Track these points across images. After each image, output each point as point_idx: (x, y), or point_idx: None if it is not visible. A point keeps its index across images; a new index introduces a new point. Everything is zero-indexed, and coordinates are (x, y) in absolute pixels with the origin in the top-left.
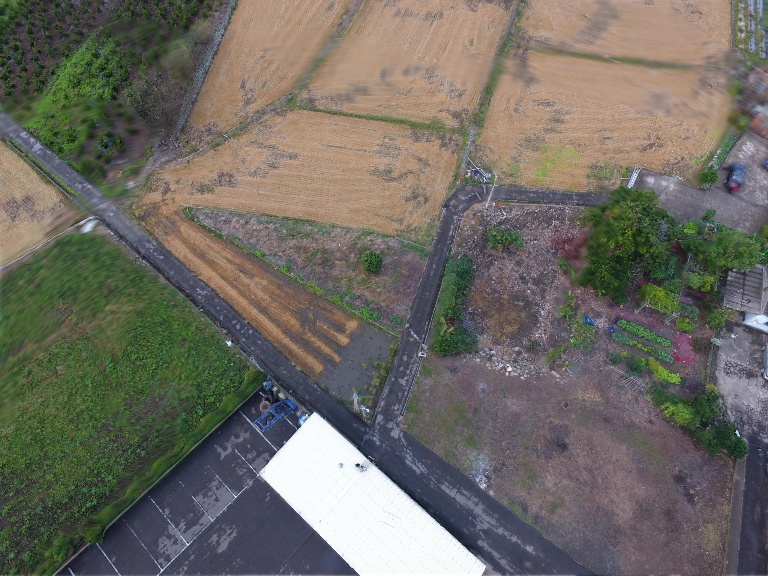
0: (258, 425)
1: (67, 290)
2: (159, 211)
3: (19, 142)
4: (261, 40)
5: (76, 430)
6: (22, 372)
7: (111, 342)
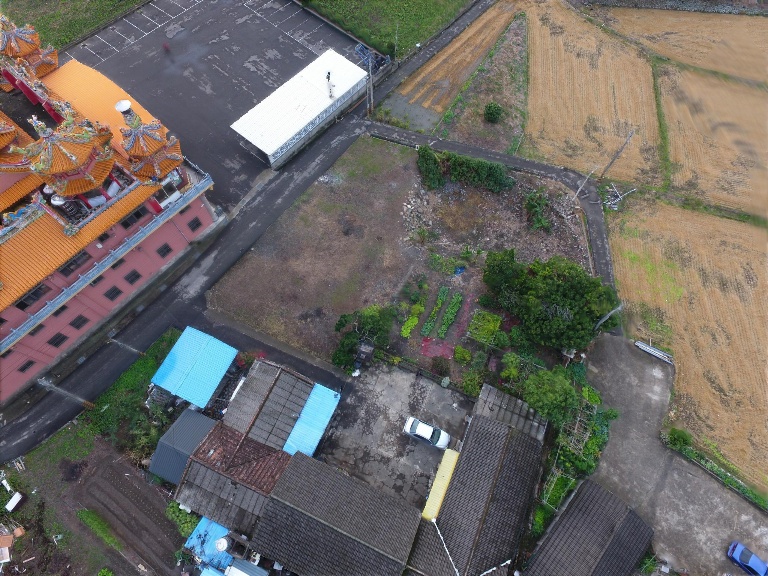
0: (359, 46)
1: None
2: (519, 1)
3: None
4: (737, 38)
5: None
6: None
7: None
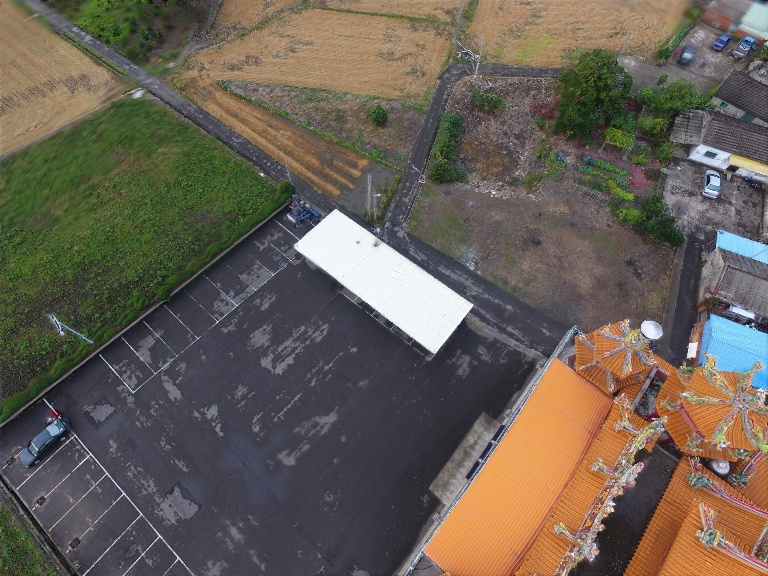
0: (291, 215)
1: (124, 139)
2: (197, 84)
3: (72, 35)
4: None
5: (140, 234)
6: (92, 195)
7: (164, 174)
